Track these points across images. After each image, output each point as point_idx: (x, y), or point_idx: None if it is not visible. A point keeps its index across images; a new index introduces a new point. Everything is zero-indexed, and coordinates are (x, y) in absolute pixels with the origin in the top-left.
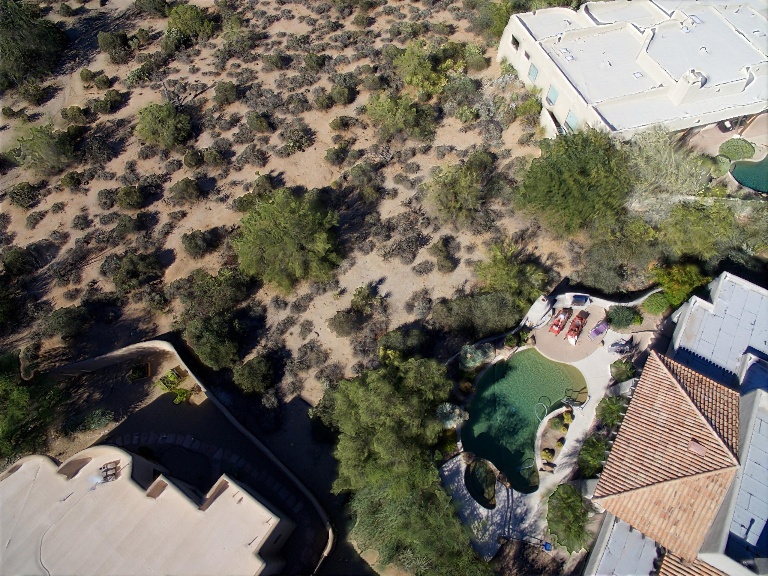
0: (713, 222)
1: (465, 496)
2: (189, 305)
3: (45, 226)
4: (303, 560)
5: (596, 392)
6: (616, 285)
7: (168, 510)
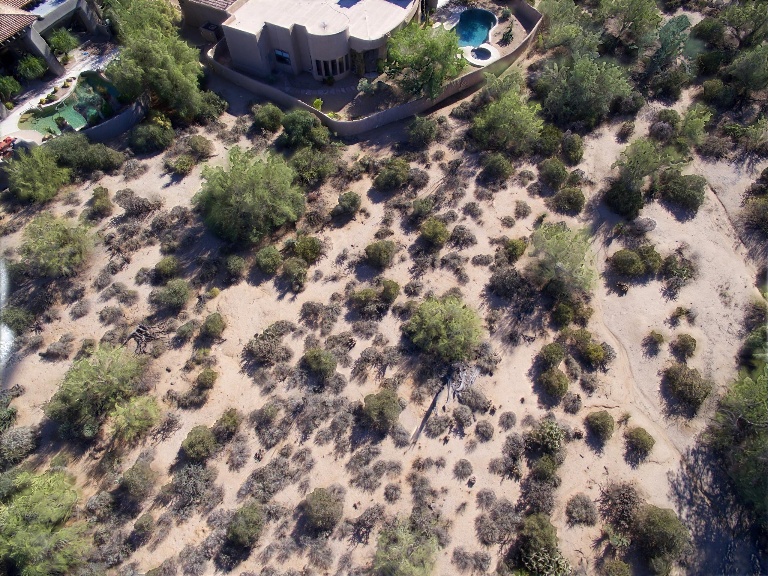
0: None
1: None
2: None
3: (508, 204)
4: (230, 58)
5: (15, 117)
6: None
7: None
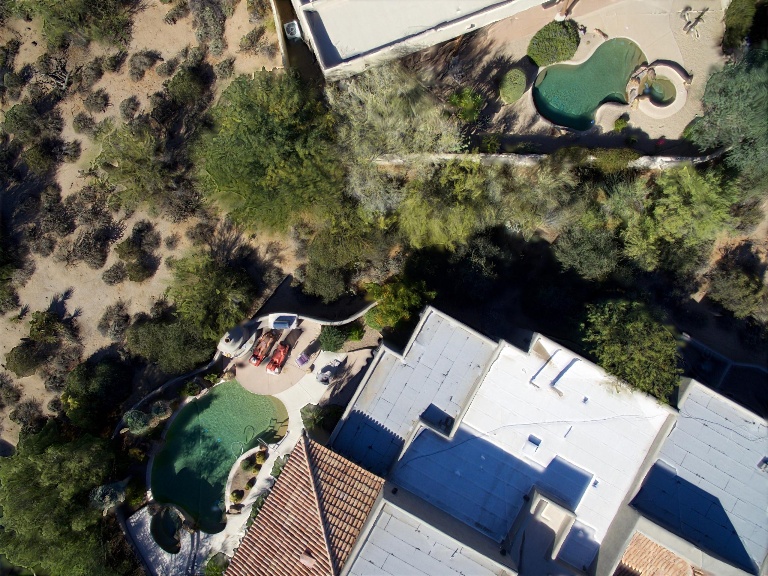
0: (460, 206)
1: (150, 544)
2: None
3: None
4: None
5: (296, 426)
6: (339, 291)
7: None
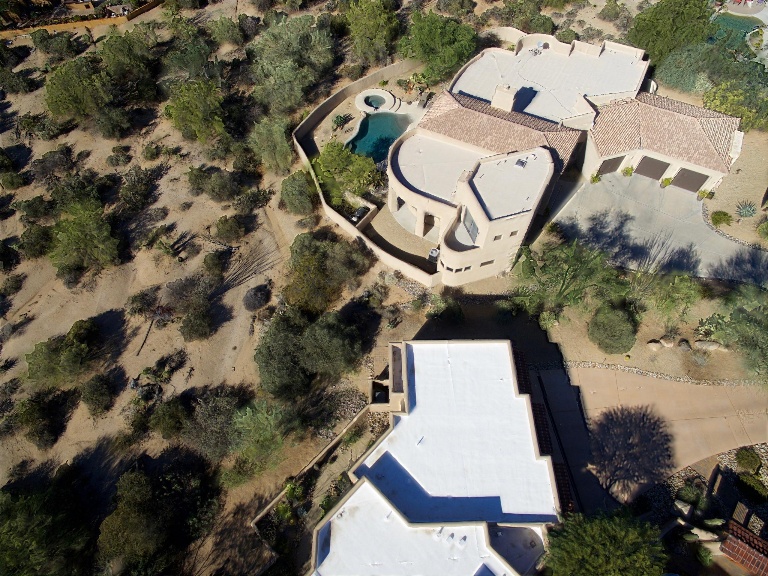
0: None
1: None
2: (501, 21)
3: None
4: None
5: None
6: None
7: (578, 59)
